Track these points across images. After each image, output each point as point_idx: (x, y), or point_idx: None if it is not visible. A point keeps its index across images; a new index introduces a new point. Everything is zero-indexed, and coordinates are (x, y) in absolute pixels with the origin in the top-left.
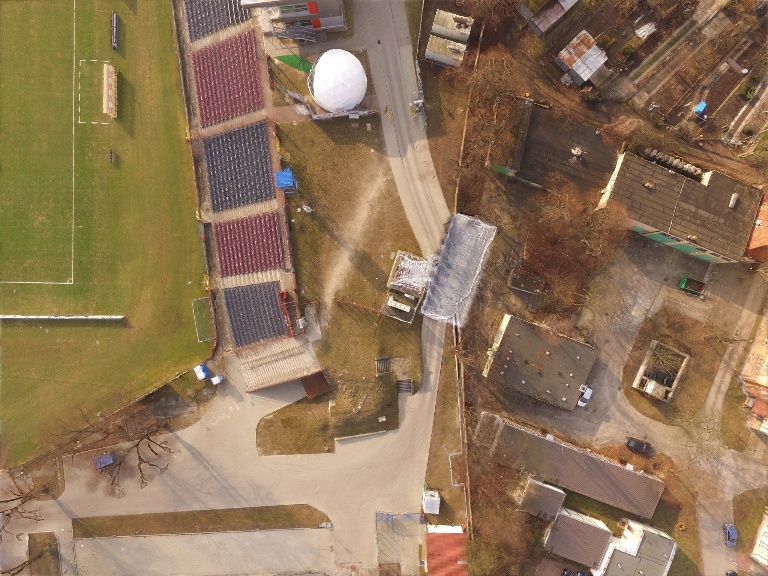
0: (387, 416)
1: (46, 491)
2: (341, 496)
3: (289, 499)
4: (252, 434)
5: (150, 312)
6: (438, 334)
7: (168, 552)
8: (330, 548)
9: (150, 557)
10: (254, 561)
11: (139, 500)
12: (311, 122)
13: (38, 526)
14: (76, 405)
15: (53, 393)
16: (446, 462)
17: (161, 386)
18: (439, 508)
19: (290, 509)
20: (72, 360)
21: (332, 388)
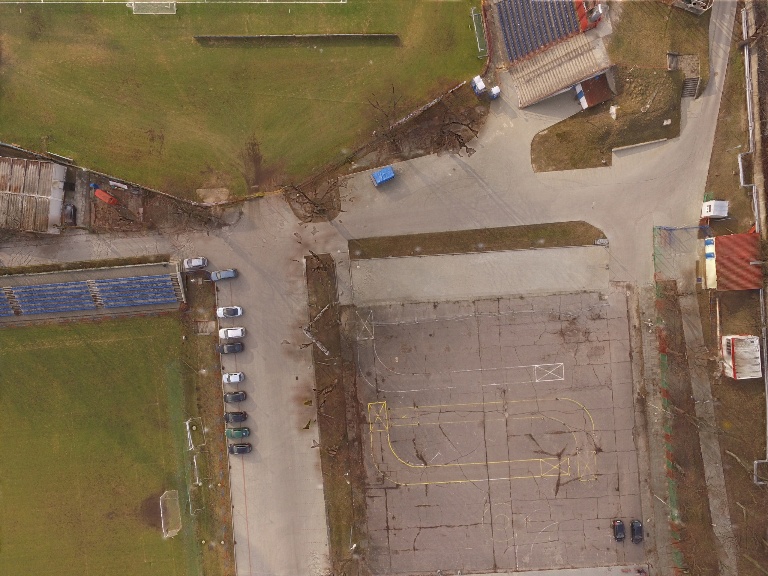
0: (671, 121)
1: (323, 212)
2: (617, 211)
3: (564, 216)
4: (527, 150)
5: (422, 30)
6: (725, 31)
7: (443, 273)
8: (606, 266)
9: (425, 278)
10: (529, 281)
11: (414, 220)
12: None
13: (314, 248)
14: (350, 125)
15: (328, 114)
16: (729, 169)
17: (439, 100)
18: (727, 211)
19: (565, 226)
20: (346, 80)
21: (613, 95)
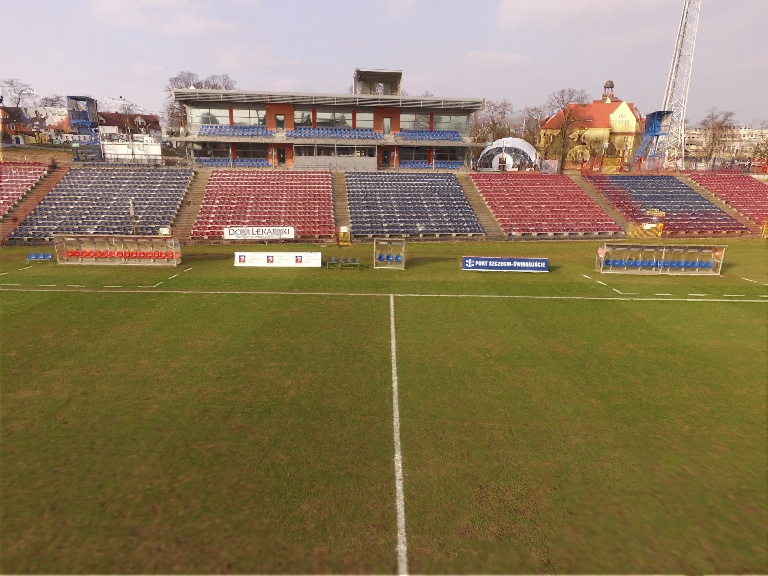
0: None
1: None
2: None
3: None
4: None
5: None
6: None
7: None
8: None
9: None
10: None
11: None
12: None
13: None
14: None
15: None
16: None
17: None
18: None
19: None
20: None
21: None
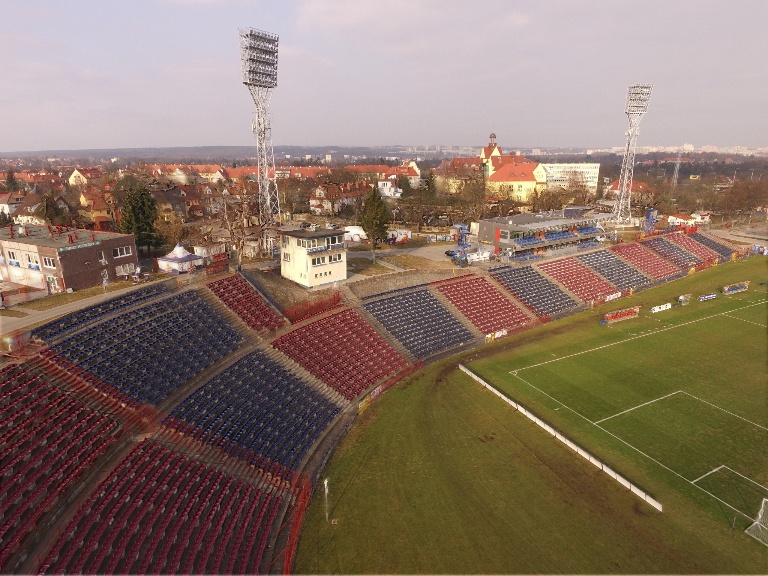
0: None
1: None
2: None
3: None
4: None
5: None
6: None
7: None
8: None
9: None
10: None
11: None
12: None
13: None
14: None
15: None
16: None
17: None
18: None
19: None
20: None
21: None
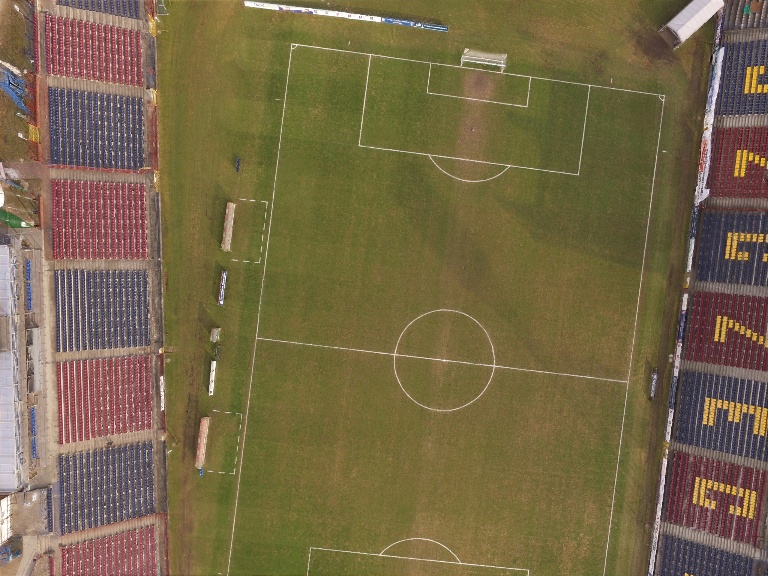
0: None
1: None
2: None
3: None
4: None
5: (219, 7)
6: None
7: None
8: None
9: None
10: None
11: None
12: (5, 161)
13: None
14: None
15: None
16: None
17: None
18: None
19: None
20: None
21: None
